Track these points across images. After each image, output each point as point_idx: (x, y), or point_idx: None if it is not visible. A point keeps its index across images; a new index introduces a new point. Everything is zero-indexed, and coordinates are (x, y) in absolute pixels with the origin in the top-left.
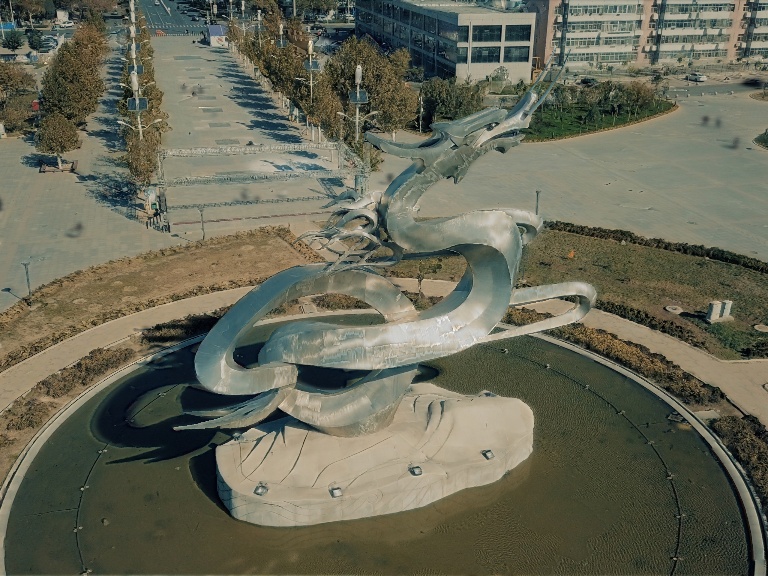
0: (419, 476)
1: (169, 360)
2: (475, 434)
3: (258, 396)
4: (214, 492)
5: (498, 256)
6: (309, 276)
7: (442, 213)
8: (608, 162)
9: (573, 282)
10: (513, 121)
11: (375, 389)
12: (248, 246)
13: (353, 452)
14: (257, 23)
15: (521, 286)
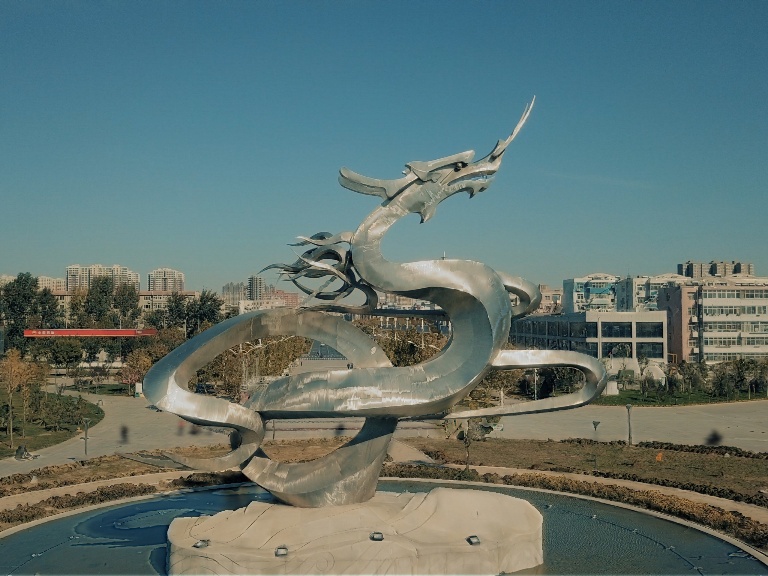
0: (379, 542)
1: (186, 496)
2: (462, 521)
3: None
4: (163, 566)
5: (477, 305)
6: (275, 310)
7: (530, 437)
8: (733, 417)
9: None
10: (481, 163)
11: (347, 455)
12: (316, 446)
13: (313, 519)
14: (394, 323)
15: (590, 472)
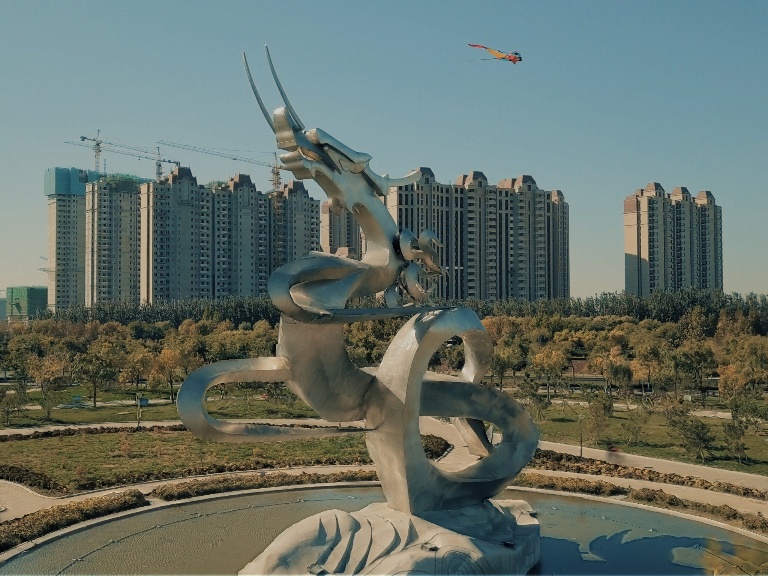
0: None
1: None
2: None
3: (493, 446)
4: None
5: None
6: None
7: None
8: None
9: (213, 363)
10: None
11: None
12: None
13: None
14: None
15: None
